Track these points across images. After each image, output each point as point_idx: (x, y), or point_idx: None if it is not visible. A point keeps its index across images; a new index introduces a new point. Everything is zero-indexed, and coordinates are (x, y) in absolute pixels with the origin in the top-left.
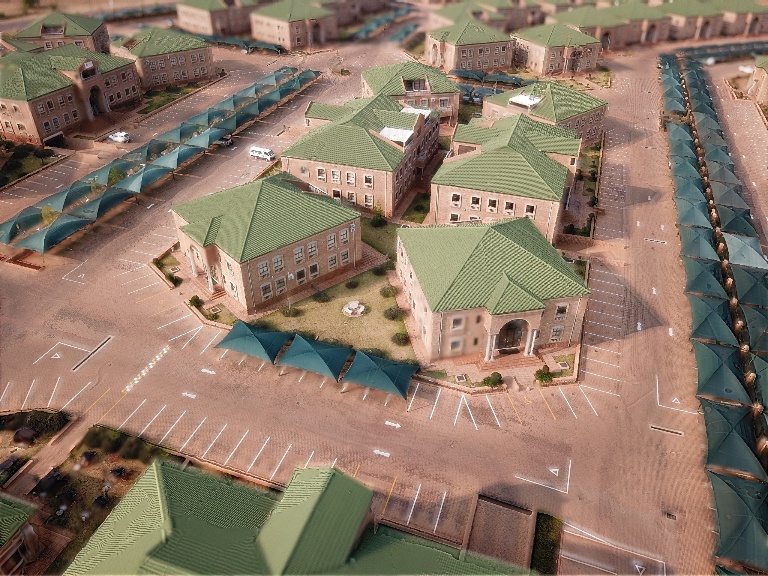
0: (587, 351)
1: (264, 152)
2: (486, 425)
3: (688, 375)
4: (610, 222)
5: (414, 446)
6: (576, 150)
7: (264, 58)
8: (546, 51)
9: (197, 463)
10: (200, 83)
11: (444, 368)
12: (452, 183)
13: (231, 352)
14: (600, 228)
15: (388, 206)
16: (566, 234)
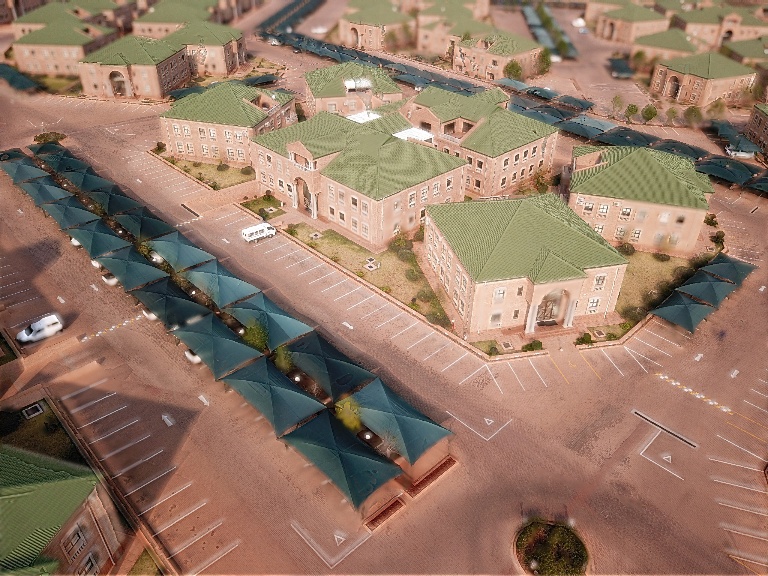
0: None
1: (267, 228)
2: (759, 257)
3: None
4: None
5: None
6: (505, 96)
7: None
8: (224, 49)
9: None
10: None
11: (699, 252)
12: (505, 150)
13: (670, 339)
14: None
15: (462, 200)
16: None
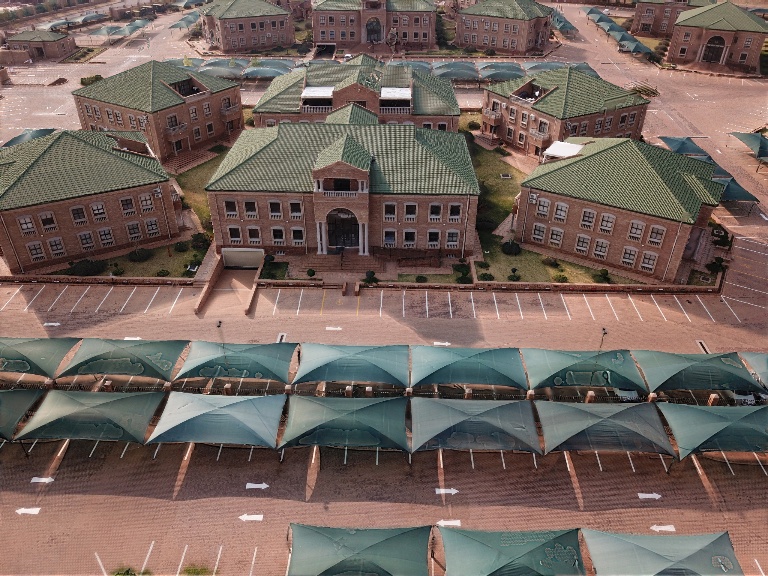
0: (10, 287)
1: None
2: None
3: None
4: (324, 301)
5: None
6: None
7: (621, 58)
8: None
9: None
10: (502, 54)
11: None
12: (239, 138)
13: None
14: (300, 292)
15: None
16: (262, 262)
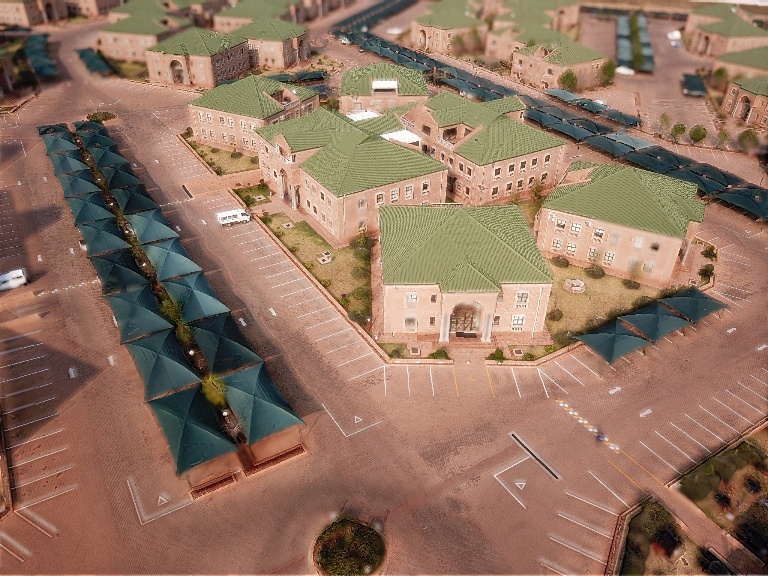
0: None
1: (241, 214)
2: (748, 297)
3: (726, 217)
4: None
5: (759, 332)
6: (521, 105)
7: None
8: (283, 45)
9: (748, 438)
10: None
11: (678, 283)
12: None
13: (593, 368)
14: None
15: None
16: None
